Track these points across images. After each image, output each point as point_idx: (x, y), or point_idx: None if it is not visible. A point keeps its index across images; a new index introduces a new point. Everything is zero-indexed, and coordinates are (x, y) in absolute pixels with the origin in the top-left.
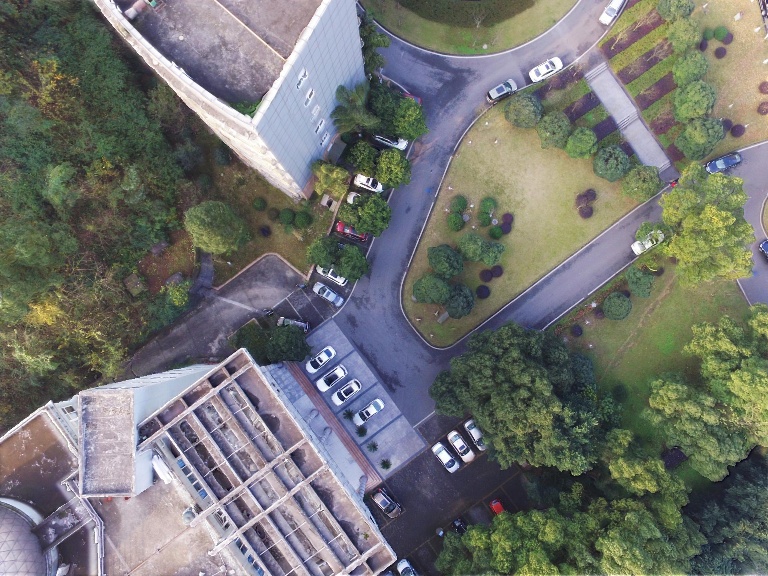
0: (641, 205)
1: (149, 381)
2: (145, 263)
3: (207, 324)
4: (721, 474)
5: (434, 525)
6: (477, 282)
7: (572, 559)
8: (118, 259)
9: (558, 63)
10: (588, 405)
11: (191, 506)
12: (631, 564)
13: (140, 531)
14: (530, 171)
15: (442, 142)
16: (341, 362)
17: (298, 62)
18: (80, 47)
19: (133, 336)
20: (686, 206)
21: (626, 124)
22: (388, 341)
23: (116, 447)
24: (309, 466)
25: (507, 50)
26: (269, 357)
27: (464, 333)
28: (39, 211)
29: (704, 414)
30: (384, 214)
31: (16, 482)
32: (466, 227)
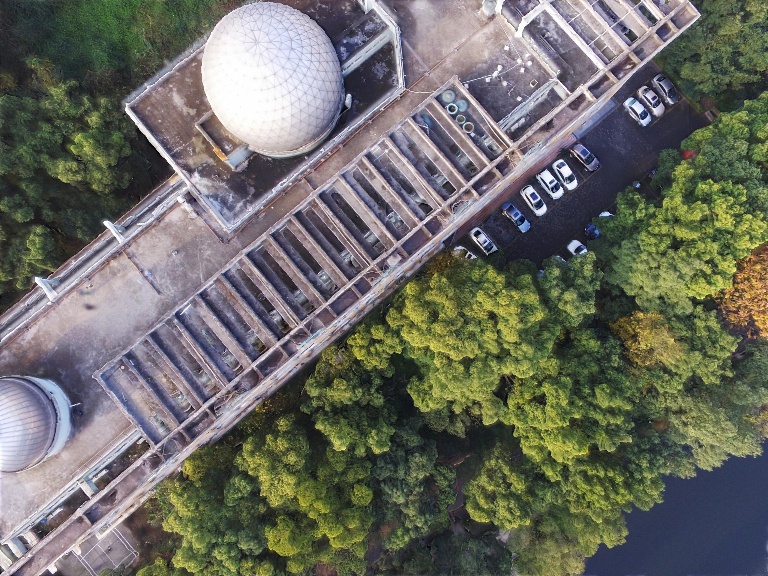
0: None
1: None
2: None
3: None
4: None
5: (630, 178)
6: None
7: None
8: None
9: None
10: None
11: None
12: None
13: (436, 33)
14: None
15: None
16: None
17: None
18: None
19: None
20: None
21: None
22: None
23: None
24: None
25: None
26: None
27: None
28: None
29: None
30: None
31: None
32: None
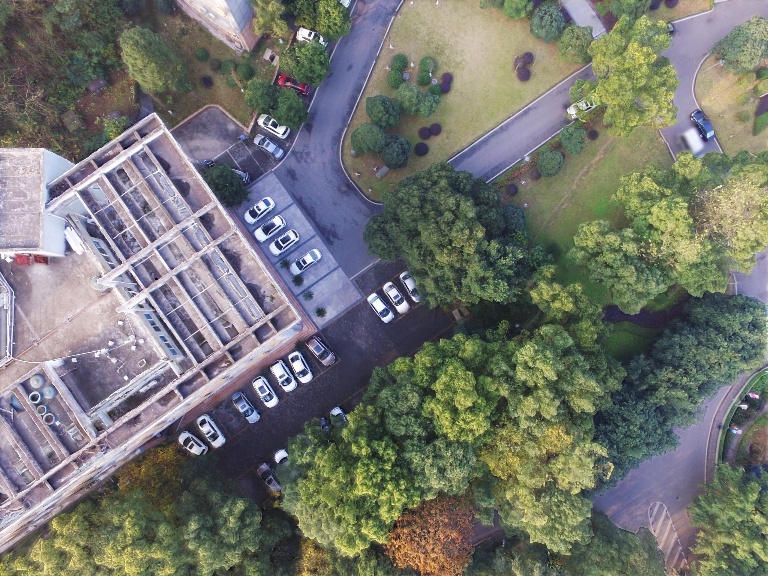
0: (578, 72)
1: None
2: (84, 103)
3: None
4: (639, 303)
5: (368, 375)
6: (416, 139)
7: (489, 372)
8: (56, 95)
9: None
10: (516, 245)
11: (101, 271)
12: (541, 361)
13: (51, 301)
14: (470, 33)
15: (385, 2)
16: (280, 214)
17: None
18: None
19: None
20: (612, 49)
21: None
22: (327, 195)
23: (25, 205)
24: (218, 230)
25: None
26: None
27: None
28: None
29: (623, 243)
30: (321, 57)
31: None
32: None
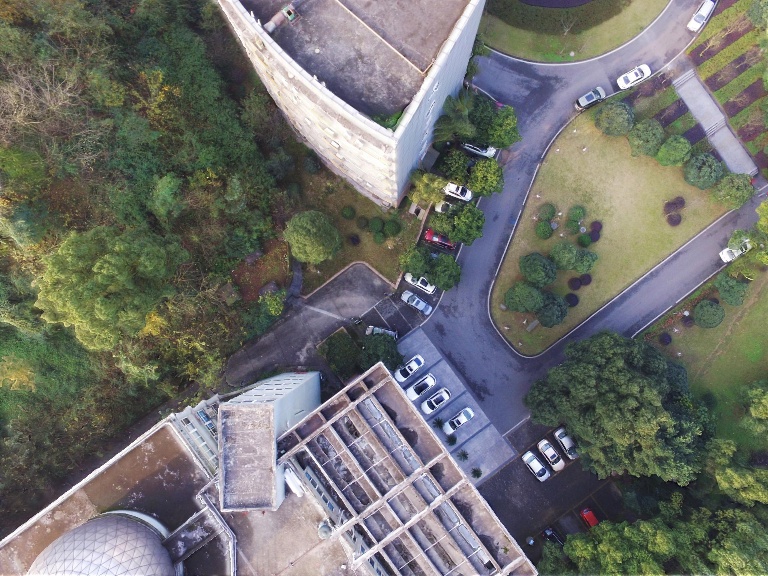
0: (728, 212)
1: (270, 393)
2: (238, 272)
3: (295, 333)
4: None
5: (524, 534)
6: (565, 290)
7: (685, 571)
8: (212, 268)
9: (646, 70)
10: (687, 414)
11: (327, 520)
12: None
13: (272, 545)
14: (618, 179)
15: (529, 150)
16: (429, 371)
17: (438, 75)
18: (176, 57)
19: (229, 346)
20: None
21: (713, 131)
22: (476, 349)
23: (255, 461)
24: (448, 480)
25: (594, 57)
26: (363, 366)
27: (552, 341)
28: (143, 222)
29: None
30: (480, 223)
31: (139, 494)
32: (554, 235)
